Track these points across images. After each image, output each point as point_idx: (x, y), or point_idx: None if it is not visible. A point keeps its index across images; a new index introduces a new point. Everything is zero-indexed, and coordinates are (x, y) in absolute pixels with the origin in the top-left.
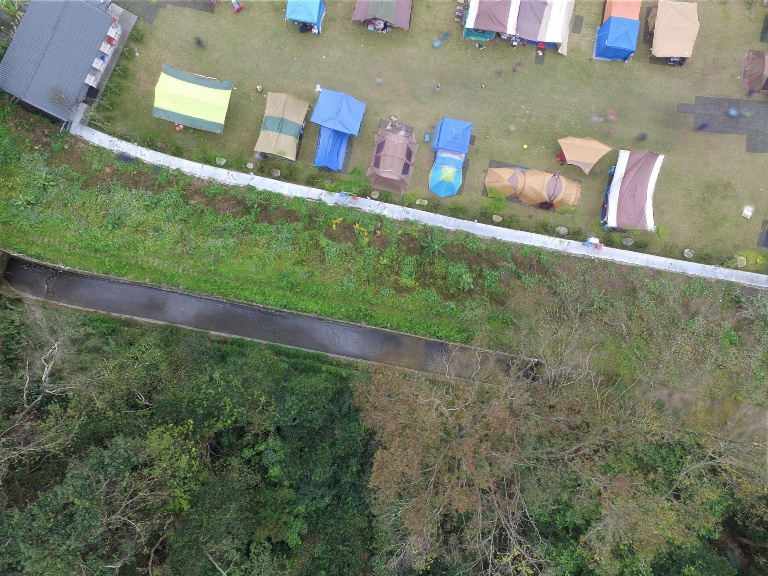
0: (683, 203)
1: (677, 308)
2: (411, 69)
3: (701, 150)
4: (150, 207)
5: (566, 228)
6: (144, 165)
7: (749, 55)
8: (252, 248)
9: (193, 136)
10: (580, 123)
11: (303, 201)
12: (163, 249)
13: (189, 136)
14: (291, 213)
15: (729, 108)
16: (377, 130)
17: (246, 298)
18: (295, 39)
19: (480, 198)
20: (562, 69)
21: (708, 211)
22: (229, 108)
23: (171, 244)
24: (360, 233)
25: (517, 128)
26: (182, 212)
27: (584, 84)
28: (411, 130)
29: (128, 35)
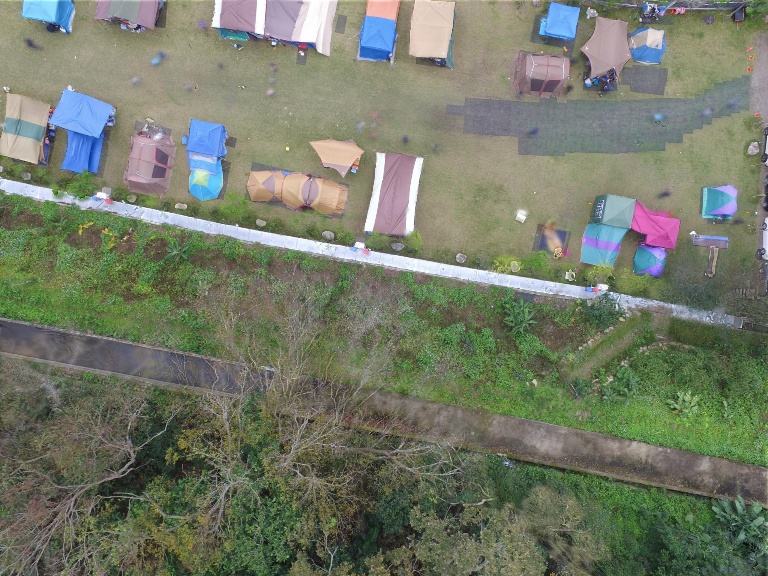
0: (455, 207)
1: (439, 315)
2: (167, 70)
3: (472, 153)
4: None
5: (333, 233)
6: None
7: (520, 56)
8: None
9: None
10: (345, 125)
11: (54, 205)
12: None
13: None
14: (36, 218)
15: (500, 110)
16: (133, 132)
17: None
18: (44, 39)
19: None
20: (325, 70)
21: (481, 215)
22: None
23: None
24: (105, 238)
25: (280, 130)
26: None
27: (348, 85)
28: (169, 132)
29: None
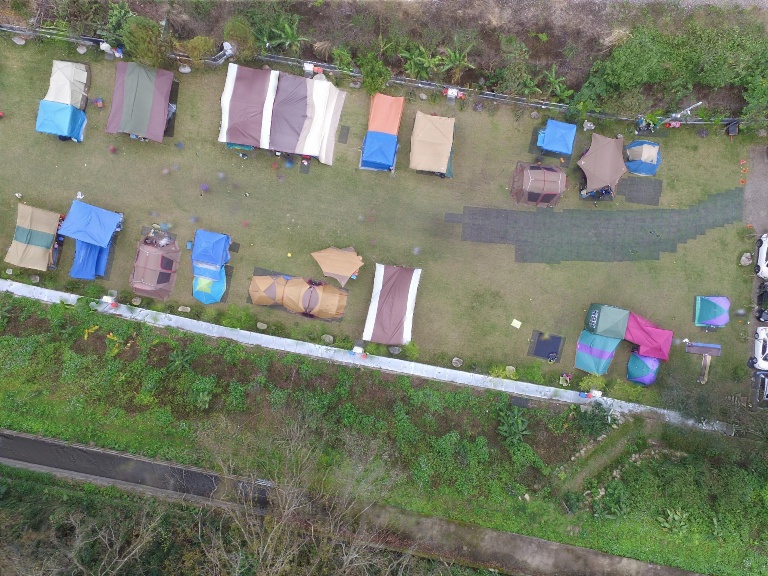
0: (452, 312)
1: (434, 422)
2: (174, 177)
3: (469, 260)
4: None
5: (332, 336)
6: None
7: (517, 166)
8: None
9: None
10: (346, 232)
11: None
12: None
13: None
14: (44, 322)
15: (497, 218)
16: (139, 237)
17: None
18: (56, 147)
19: (245, 305)
20: (328, 178)
21: (477, 320)
22: None
23: None
24: (110, 344)
25: (282, 236)
26: None
27: (350, 193)
28: (174, 237)
29: None
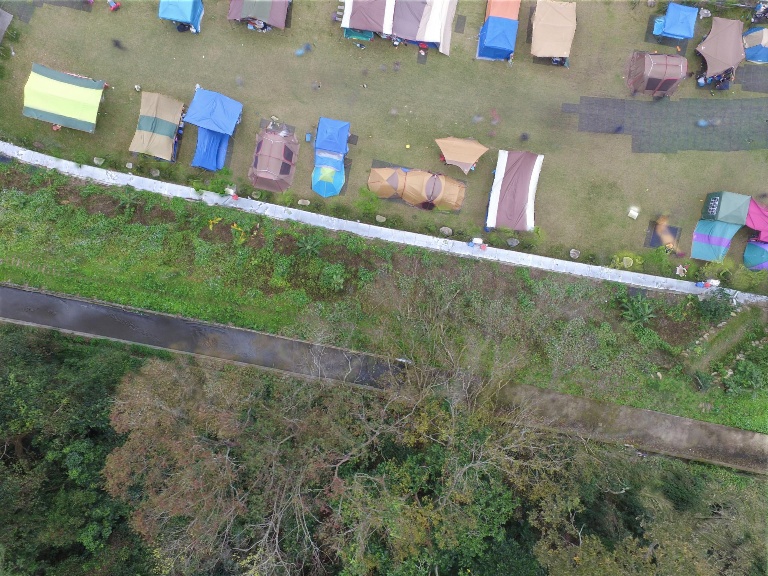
0: (569, 203)
1: (558, 309)
2: (292, 69)
3: (586, 150)
4: (18, 207)
5: (450, 228)
6: (20, 165)
7: (634, 55)
8: (120, 248)
9: (70, 136)
10: (464, 123)
11: (182, 201)
12: (25, 249)
13: (67, 136)
14: (168, 213)
15: (614, 108)
16: (258, 130)
17: (110, 299)
18: (174, 38)
19: (363, 198)
20: (445, 69)
21: (594, 211)
22: (101, 108)
23: (34, 244)
24: (236, 233)
25: (400, 128)
26: (51, 212)
27: (467, 84)
28: (293, 130)
29: (3, 34)
